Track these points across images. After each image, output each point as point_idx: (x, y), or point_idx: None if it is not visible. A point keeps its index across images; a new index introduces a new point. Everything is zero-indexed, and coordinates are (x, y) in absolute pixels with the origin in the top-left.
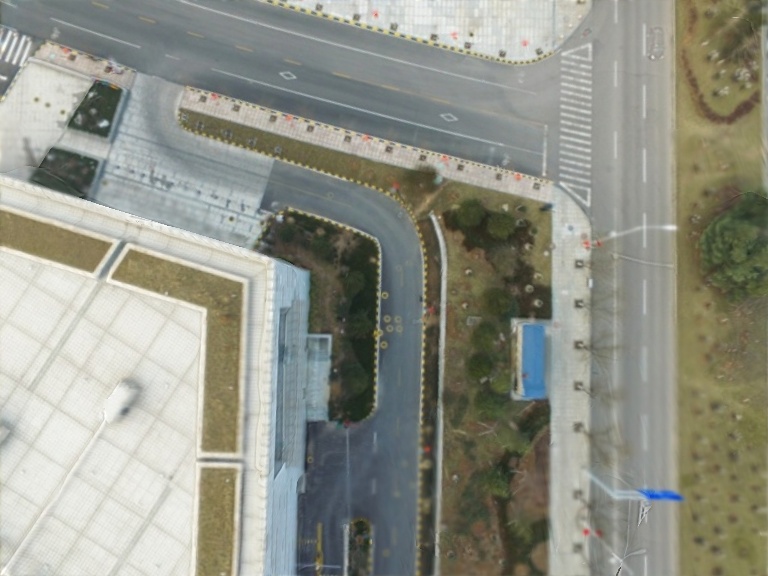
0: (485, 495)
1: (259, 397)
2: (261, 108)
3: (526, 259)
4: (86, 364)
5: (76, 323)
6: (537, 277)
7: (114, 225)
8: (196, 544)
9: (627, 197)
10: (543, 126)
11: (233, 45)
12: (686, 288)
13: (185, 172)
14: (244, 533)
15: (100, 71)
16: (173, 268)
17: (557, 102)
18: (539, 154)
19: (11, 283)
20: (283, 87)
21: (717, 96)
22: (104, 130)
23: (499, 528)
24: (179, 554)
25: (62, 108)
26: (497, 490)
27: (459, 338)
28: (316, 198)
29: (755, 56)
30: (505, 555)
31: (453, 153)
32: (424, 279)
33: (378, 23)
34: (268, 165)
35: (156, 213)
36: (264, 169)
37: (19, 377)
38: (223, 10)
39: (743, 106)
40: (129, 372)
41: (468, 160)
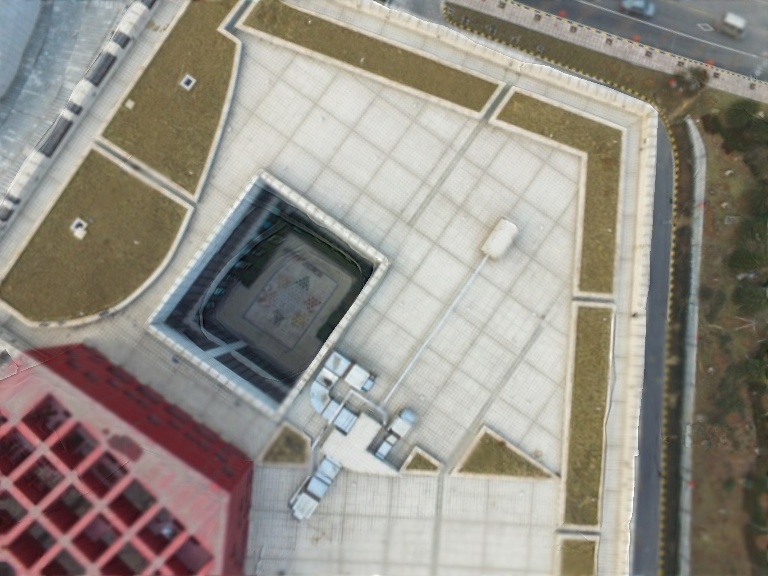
0: (741, 387)
1: (634, 241)
2: (525, 7)
3: None
4: (465, 202)
5: (456, 162)
6: None
7: (494, 70)
8: (573, 379)
9: None
10: None
11: None
12: None
13: None
14: (617, 372)
15: None
16: (556, 112)
17: None
18: None
19: (395, 119)
20: None
21: None
22: None
23: (754, 419)
24: (551, 391)
25: None
26: (758, 380)
27: (717, 236)
28: None
29: None
30: (759, 445)
31: (709, 61)
32: (674, 182)
33: None
34: None
35: None
36: None
37: (399, 212)
38: None
39: None
40: (506, 212)
41: (723, 69)
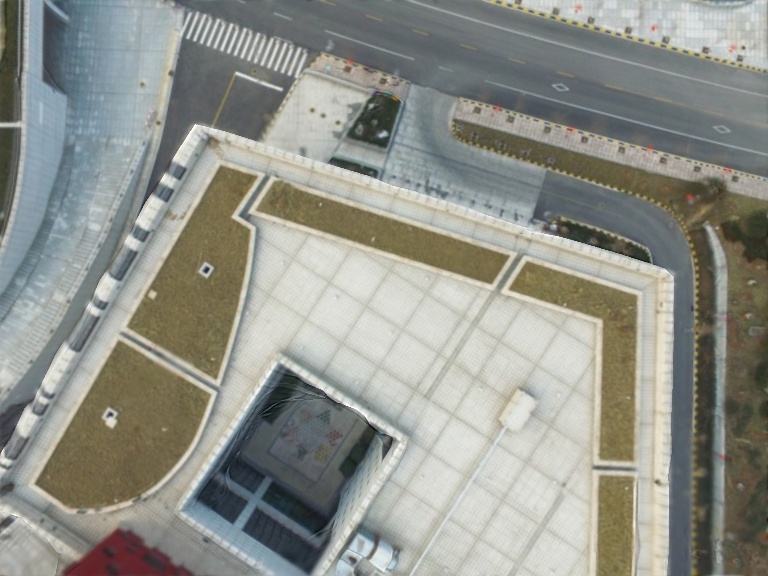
0: None
1: (654, 407)
2: (535, 119)
3: None
4: (481, 373)
5: (470, 333)
6: None
7: (505, 237)
8: (596, 550)
9: None
10: None
11: (506, 57)
12: None
13: (459, 182)
14: (641, 540)
15: (376, 83)
16: (569, 280)
17: None
18: None
19: (408, 293)
20: (556, 99)
21: None
22: (384, 140)
23: None
24: (574, 559)
25: (337, 119)
26: None
27: (741, 348)
28: (588, 208)
29: None
30: None
31: (726, 164)
32: (695, 289)
33: (652, 36)
34: (540, 175)
35: None
36: (536, 179)
37: (416, 385)
38: (495, 23)
39: None
40: (522, 381)
41: (742, 171)
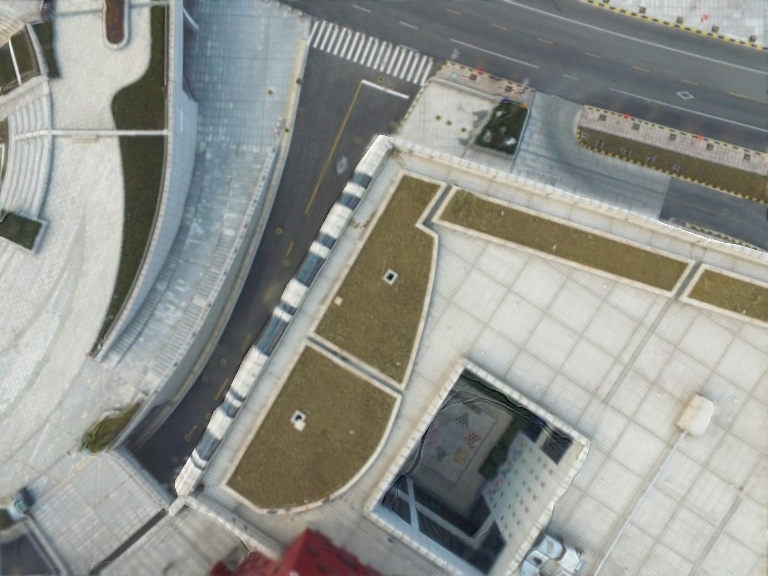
0: None
1: None
2: (660, 127)
3: None
4: (658, 378)
5: (647, 339)
6: None
7: (681, 246)
8: None
9: None
10: None
11: (630, 65)
12: None
13: (585, 188)
14: None
15: (502, 90)
16: (747, 288)
17: None
18: None
19: (586, 300)
20: (680, 106)
21: None
22: (511, 148)
23: None
24: (752, 562)
25: (463, 126)
26: None
27: None
28: (712, 214)
29: None
30: None
31: None
32: None
33: None
34: (665, 182)
35: None
36: (661, 186)
37: (594, 390)
38: (619, 31)
39: None
40: (699, 386)
41: None
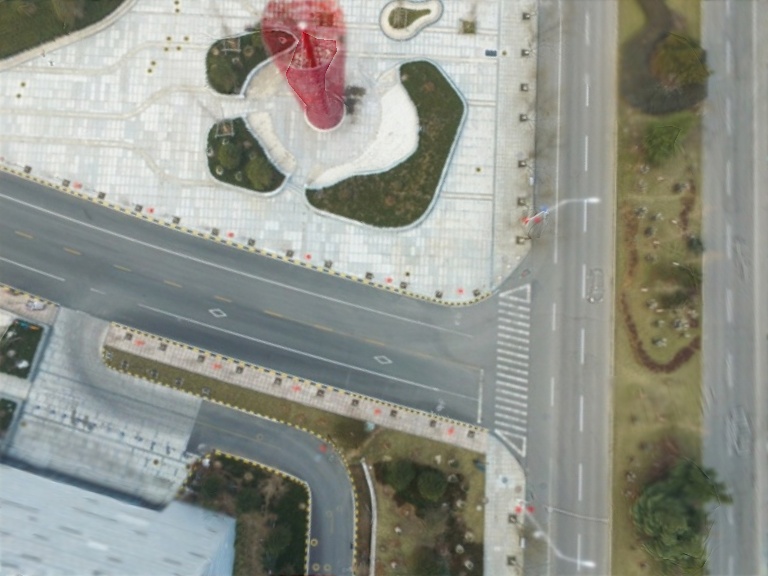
0: None
1: None
2: (189, 347)
3: (457, 516)
4: None
5: None
6: (468, 537)
7: None
8: None
9: (563, 447)
10: (479, 370)
11: (161, 280)
12: (621, 545)
13: (108, 413)
14: None
15: (21, 306)
16: None
17: (494, 346)
18: (474, 400)
19: None
20: (212, 325)
21: (655, 346)
22: (23, 371)
23: None
24: None
25: None
26: None
27: None
28: (245, 440)
29: (695, 304)
30: None
31: (386, 397)
32: (355, 525)
33: (311, 262)
34: (195, 405)
35: (77, 457)
36: (191, 410)
37: None
38: (152, 242)
39: (682, 353)
40: None
41: (401, 405)
